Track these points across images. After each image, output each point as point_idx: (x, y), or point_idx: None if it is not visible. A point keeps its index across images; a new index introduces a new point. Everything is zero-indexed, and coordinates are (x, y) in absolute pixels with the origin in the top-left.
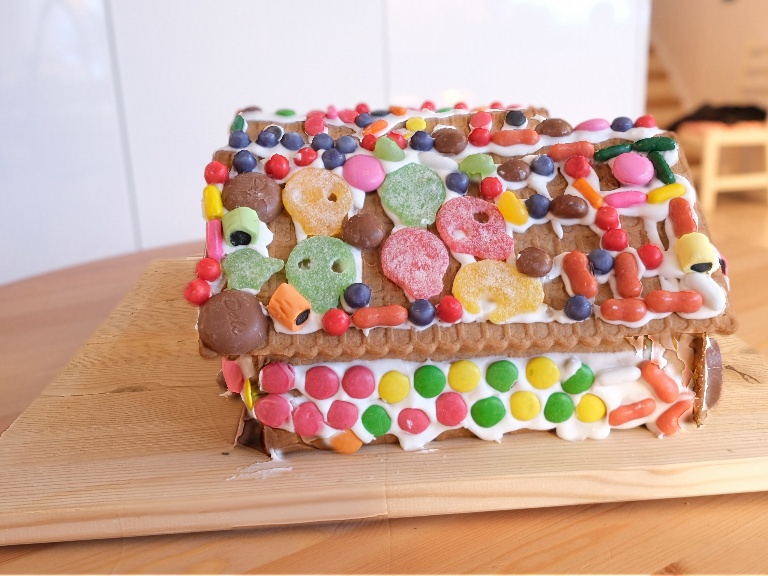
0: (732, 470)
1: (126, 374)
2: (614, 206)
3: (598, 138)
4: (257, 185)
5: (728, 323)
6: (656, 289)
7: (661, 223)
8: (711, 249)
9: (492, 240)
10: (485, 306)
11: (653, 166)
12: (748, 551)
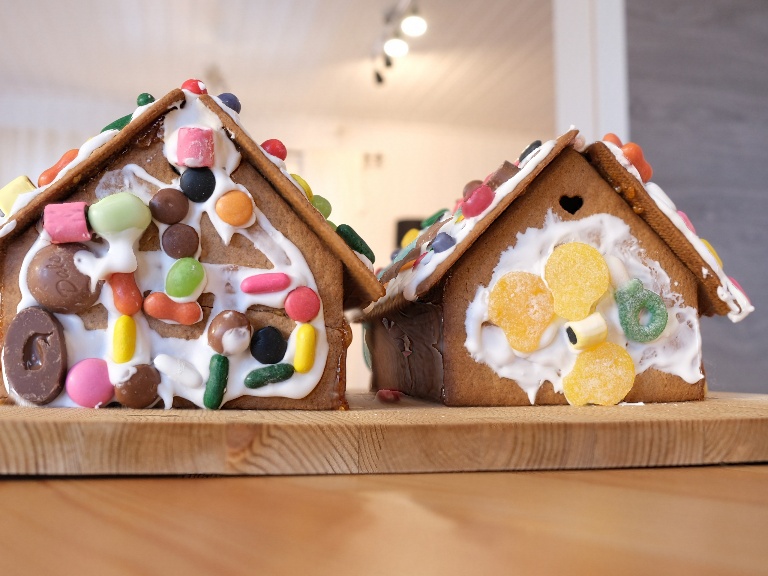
0: None
1: None
2: None
3: None
4: None
5: None
6: None
7: None
8: (22, 193)
9: None
10: None
11: None
12: None
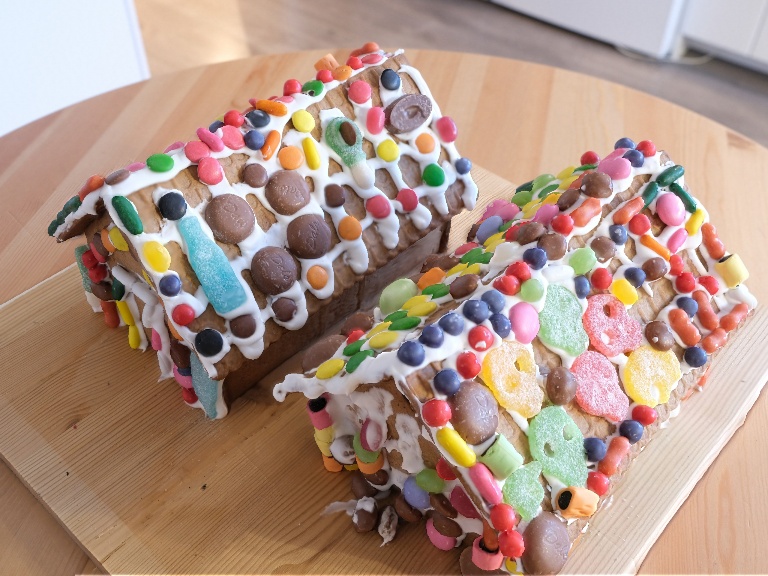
0: None
1: (234, 575)
2: (675, 252)
3: (630, 181)
4: (482, 404)
5: (752, 310)
6: (714, 308)
7: (697, 248)
8: None
9: (629, 332)
10: (653, 394)
11: (682, 201)
12: None
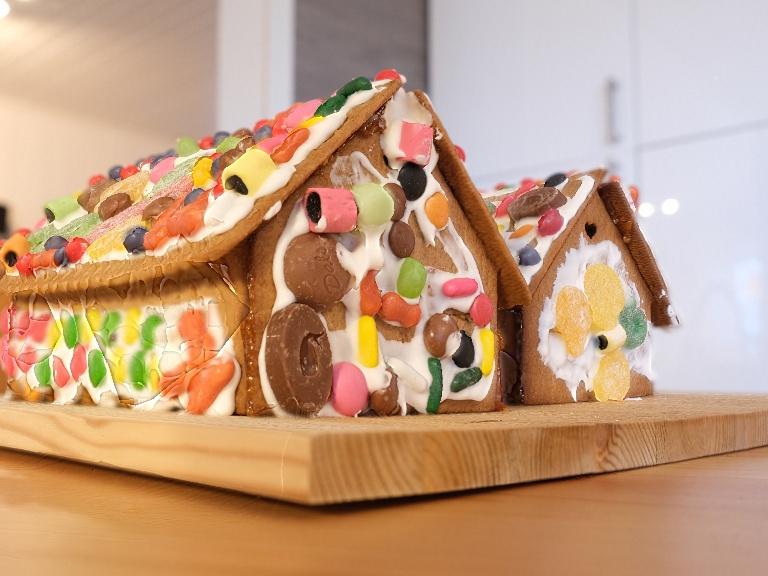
0: (136, 432)
1: None
2: None
3: None
4: None
5: None
6: None
7: None
8: (270, 169)
9: None
10: None
11: None
12: (4, 497)
